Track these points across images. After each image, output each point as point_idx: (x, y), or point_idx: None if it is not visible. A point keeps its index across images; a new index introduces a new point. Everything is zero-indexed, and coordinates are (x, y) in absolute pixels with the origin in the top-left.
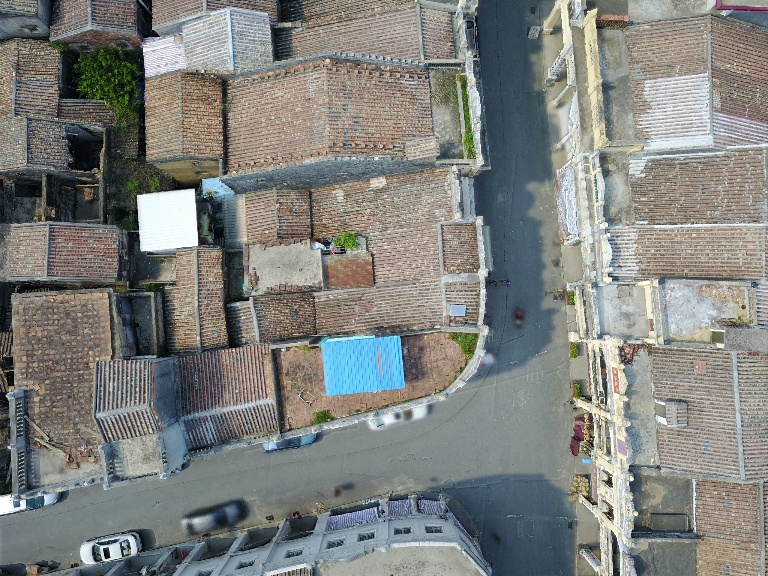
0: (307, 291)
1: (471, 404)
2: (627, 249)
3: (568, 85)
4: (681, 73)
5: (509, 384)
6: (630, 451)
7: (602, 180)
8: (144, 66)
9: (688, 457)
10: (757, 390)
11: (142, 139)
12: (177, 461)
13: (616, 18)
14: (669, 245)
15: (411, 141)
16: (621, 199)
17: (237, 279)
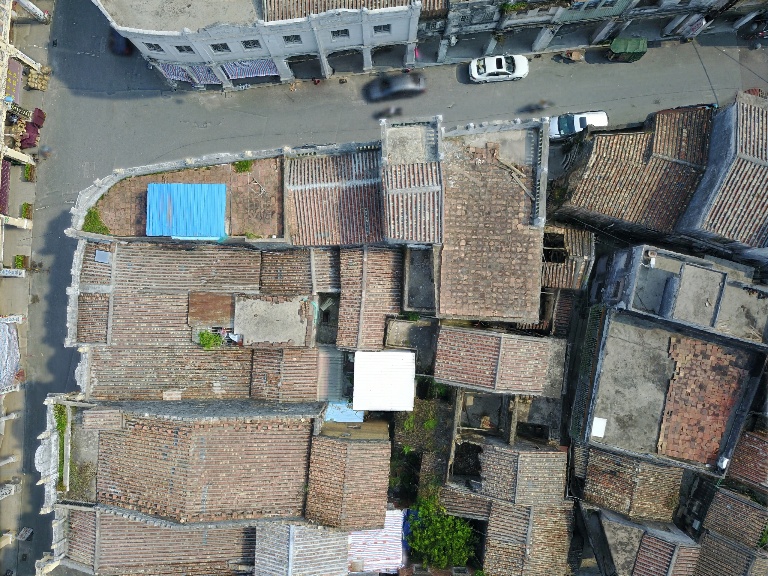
0: None
1: None
2: None
3: None
4: None
5: None
6: None
7: None
8: None
9: None
10: None
11: None
12: None
13: None
14: None
15: None
16: None
17: (336, 317)
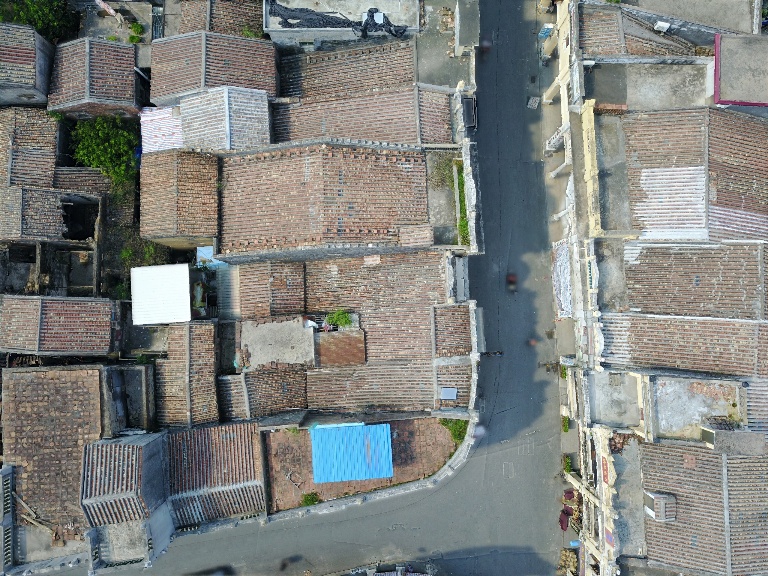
0: (299, 367)
1: (461, 475)
2: (620, 336)
3: (565, 163)
4: (678, 164)
5: (500, 455)
6: (617, 545)
7: (596, 268)
8: (141, 134)
9: (675, 551)
10: (746, 486)
11: (138, 205)
12: (163, 543)
13: (614, 107)
14: (662, 335)
15: (405, 227)
16: (615, 285)
17: (229, 349)
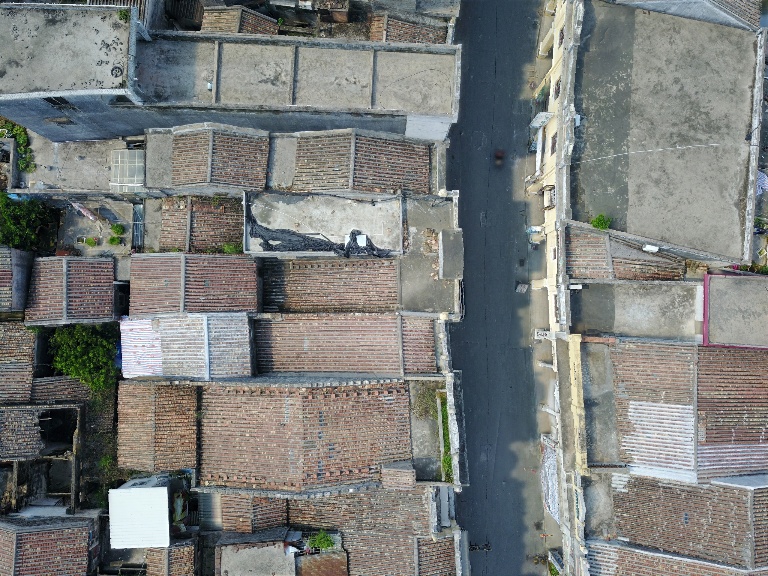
0: None
1: None
2: (607, 568)
3: (553, 369)
4: (666, 400)
5: None
6: None
7: (583, 503)
8: None
9: None
10: None
11: None
12: None
13: (601, 340)
14: (650, 572)
15: (387, 469)
16: (603, 511)
17: (210, 558)
